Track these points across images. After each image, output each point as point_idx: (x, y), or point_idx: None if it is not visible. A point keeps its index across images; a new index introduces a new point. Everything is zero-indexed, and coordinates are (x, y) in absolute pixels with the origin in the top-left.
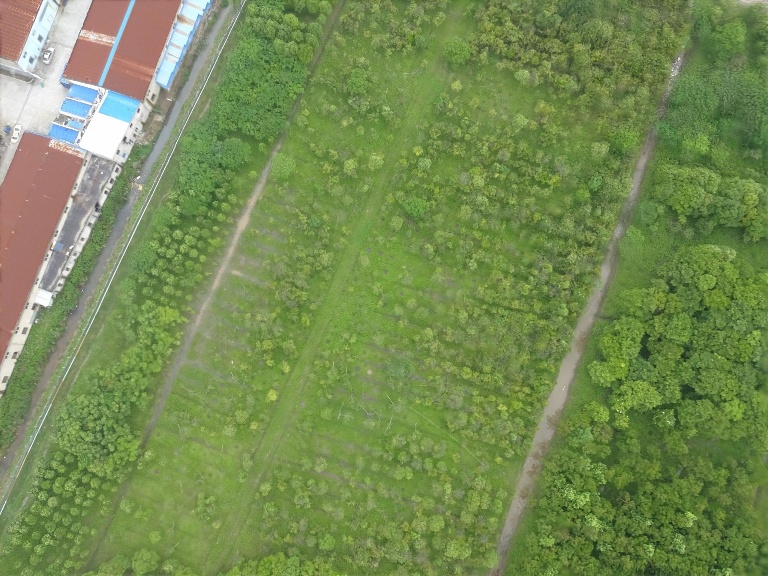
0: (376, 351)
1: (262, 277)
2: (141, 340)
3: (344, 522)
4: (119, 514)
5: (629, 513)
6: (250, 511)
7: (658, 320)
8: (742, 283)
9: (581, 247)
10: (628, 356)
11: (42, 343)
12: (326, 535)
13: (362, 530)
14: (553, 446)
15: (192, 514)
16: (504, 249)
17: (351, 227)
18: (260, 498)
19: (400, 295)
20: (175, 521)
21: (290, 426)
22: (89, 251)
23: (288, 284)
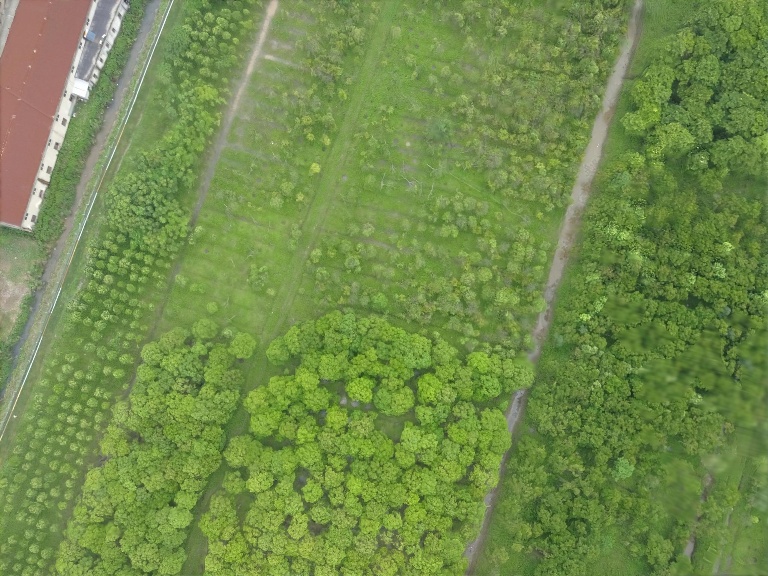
0: (413, 123)
1: (295, 59)
2: (183, 116)
3: (395, 282)
4: (174, 293)
5: (670, 242)
6: (302, 281)
7: (687, 64)
8: (766, 21)
9: (607, 9)
10: (660, 100)
11: (82, 135)
12: (379, 293)
13: (412, 290)
14: (593, 191)
15: (245, 288)
16: (533, 12)
17: (380, 5)
18: (311, 264)
19: (432, 68)
20: (229, 295)
21: (334, 199)
22: (121, 43)
23: (322, 61)
